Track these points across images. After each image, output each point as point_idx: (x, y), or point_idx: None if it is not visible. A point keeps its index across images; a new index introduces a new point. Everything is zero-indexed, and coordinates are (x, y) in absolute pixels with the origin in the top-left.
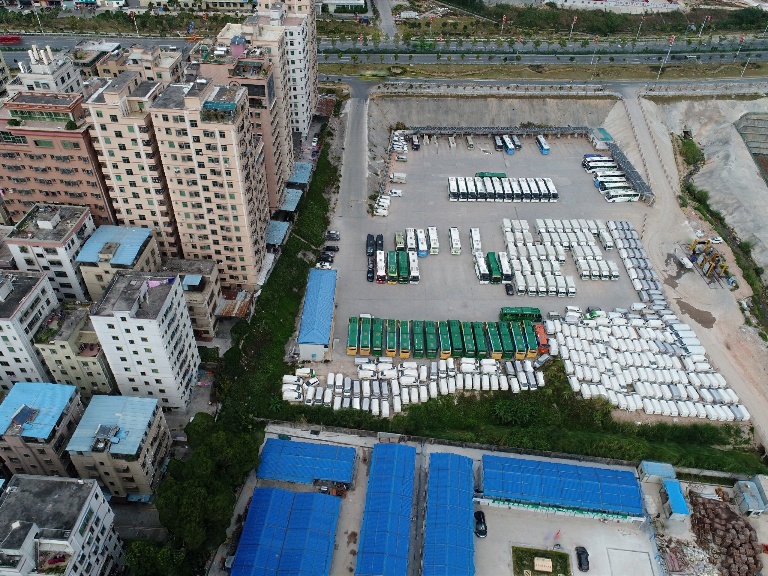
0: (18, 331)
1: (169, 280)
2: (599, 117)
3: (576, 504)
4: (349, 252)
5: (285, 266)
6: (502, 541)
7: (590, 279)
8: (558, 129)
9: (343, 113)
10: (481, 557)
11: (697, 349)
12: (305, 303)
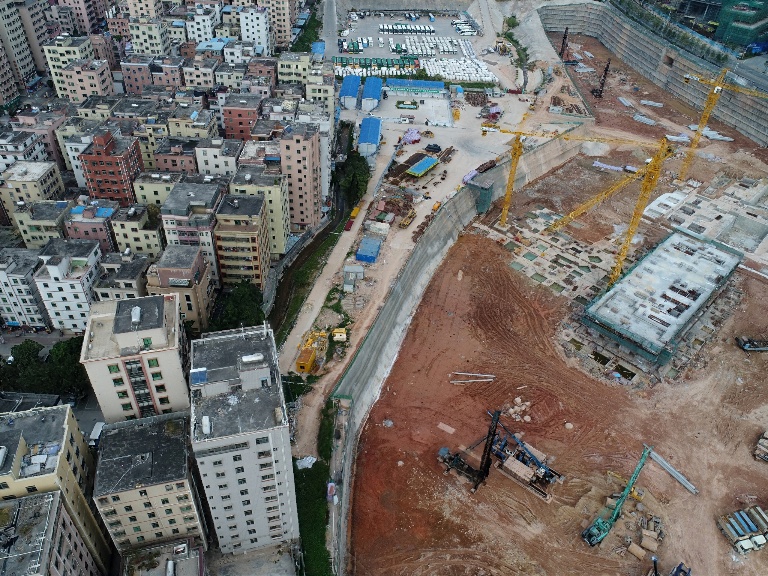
0: (210, 23)
1: (264, 8)
2: (464, 8)
3: (420, 86)
4: (330, 45)
5: (300, 44)
6: (393, 100)
7: (444, 54)
8: (440, 10)
9: (322, 2)
10: (385, 102)
11: (484, 66)
12: (312, 49)
